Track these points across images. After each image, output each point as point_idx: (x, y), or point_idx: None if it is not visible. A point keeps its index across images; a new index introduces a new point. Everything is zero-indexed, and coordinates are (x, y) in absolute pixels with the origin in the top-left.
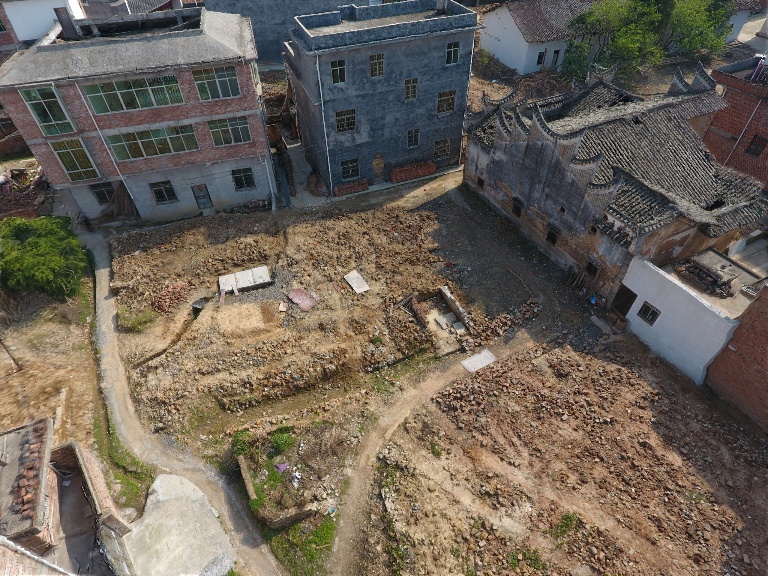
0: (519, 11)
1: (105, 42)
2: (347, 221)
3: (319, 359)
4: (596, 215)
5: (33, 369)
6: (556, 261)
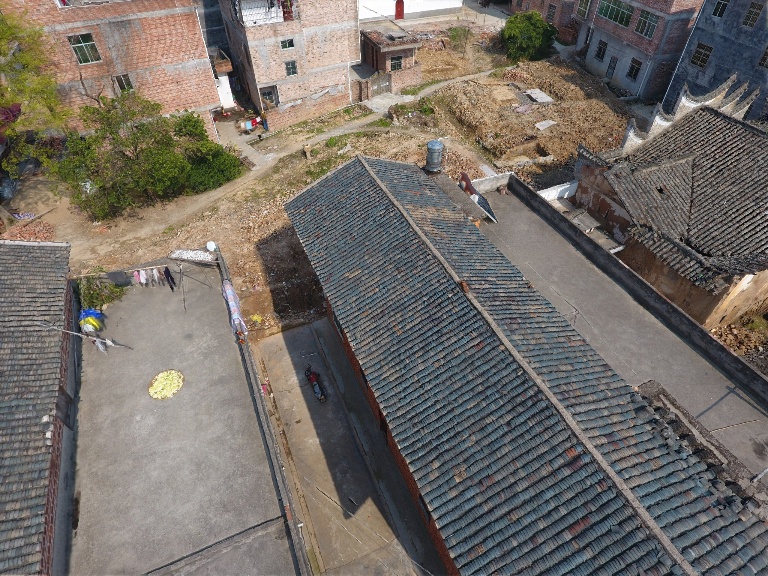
0: None
1: None
2: (616, 119)
3: None
4: None
5: (463, 61)
6: None
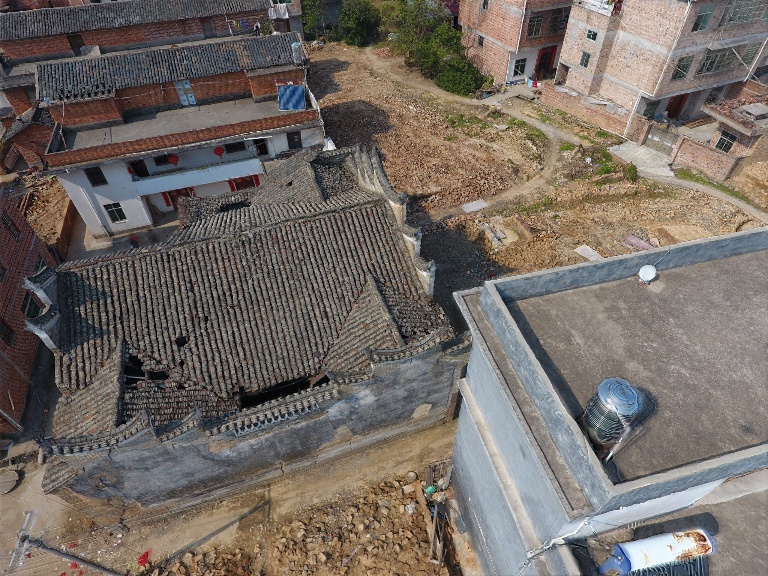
0: None
1: None
2: None
3: None
4: None
5: None
6: None
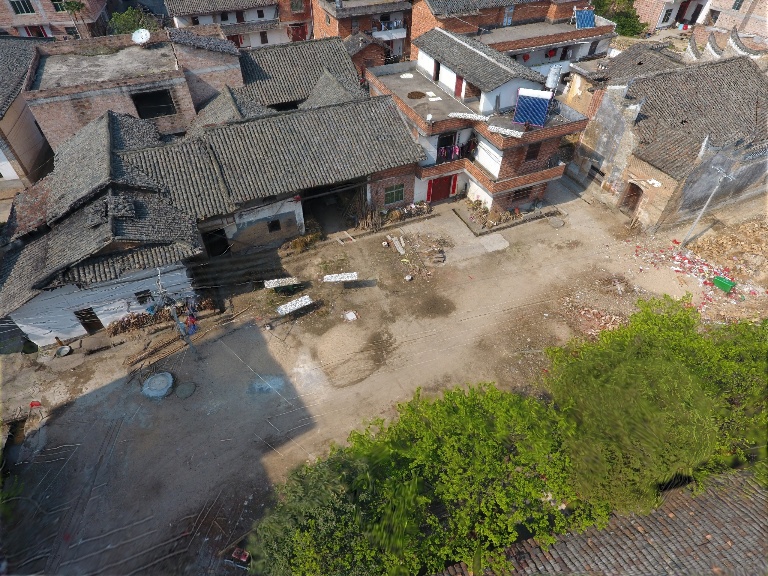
0: None
1: None
2: None
3: None
4: None
5: None
6: None
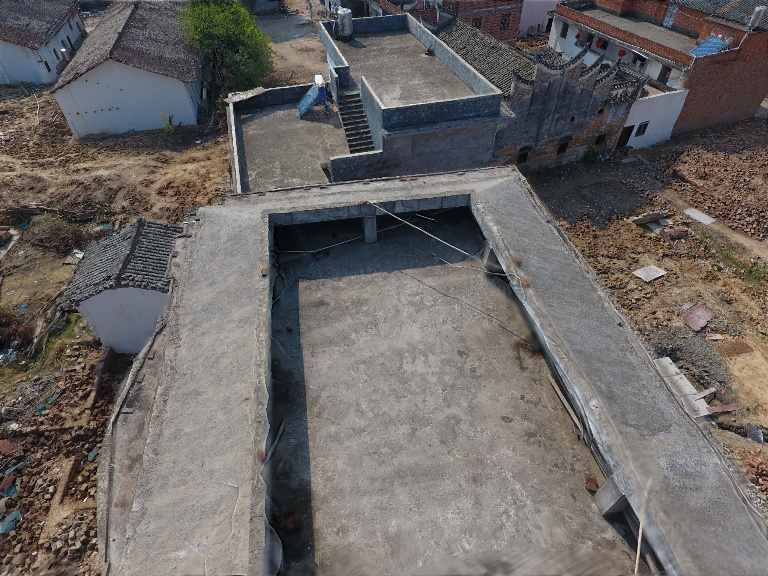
0: (133, 60)
1: (579, 375)
2: None
3: (766, 307)
4: (604, 99)
5: None
6: (568, 161)
